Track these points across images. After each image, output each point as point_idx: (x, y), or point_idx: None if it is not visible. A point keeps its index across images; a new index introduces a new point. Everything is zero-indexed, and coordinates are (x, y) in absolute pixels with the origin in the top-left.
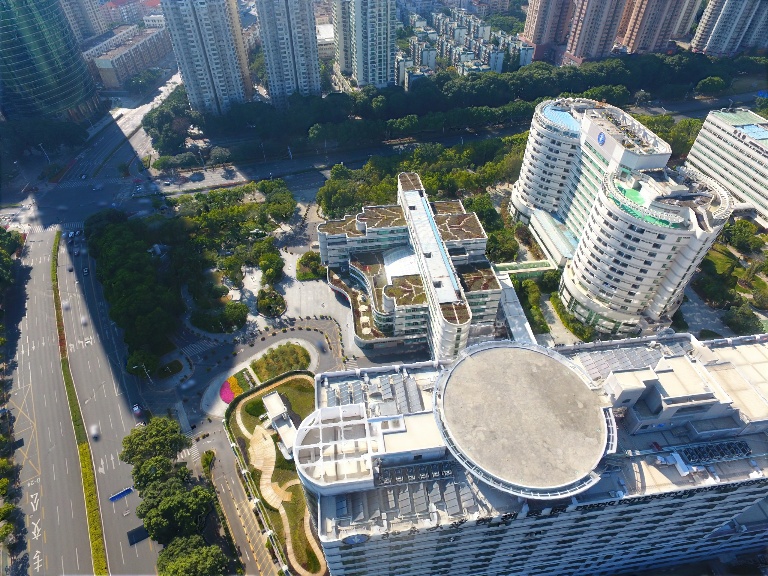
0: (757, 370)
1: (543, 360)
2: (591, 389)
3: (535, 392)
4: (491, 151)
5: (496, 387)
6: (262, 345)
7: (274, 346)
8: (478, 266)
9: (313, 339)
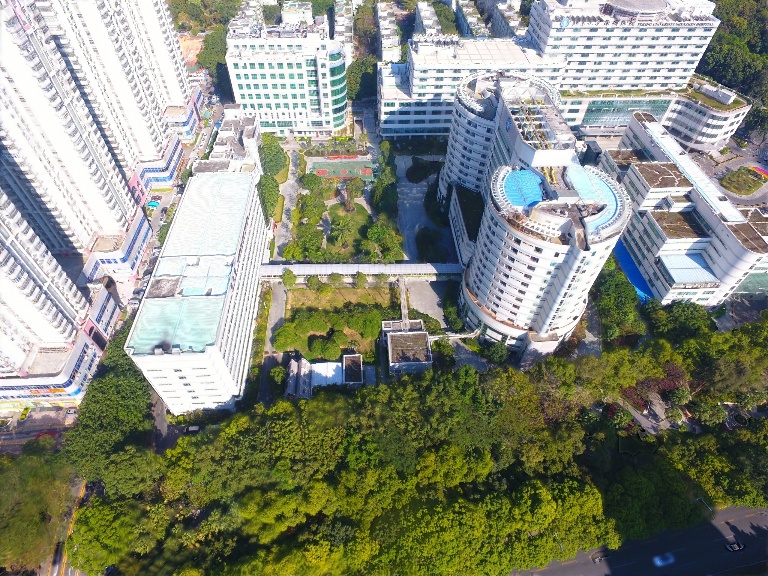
0: (492, 57)
1: (629, 8)
2: (610, 2)
3: (631, 3)
4: (623, 466)
5: (647, 4)
6: (767, 197)
7: (757, 195)
8: (628, 167)
9: (730, 198)
